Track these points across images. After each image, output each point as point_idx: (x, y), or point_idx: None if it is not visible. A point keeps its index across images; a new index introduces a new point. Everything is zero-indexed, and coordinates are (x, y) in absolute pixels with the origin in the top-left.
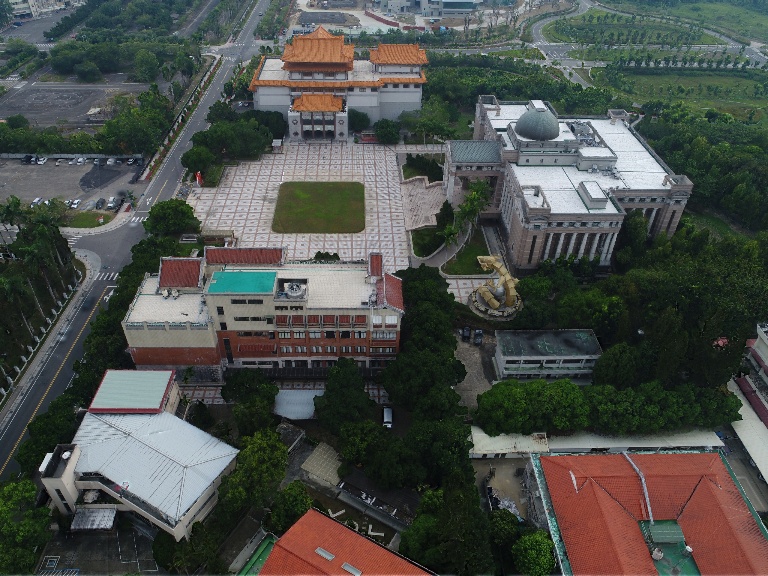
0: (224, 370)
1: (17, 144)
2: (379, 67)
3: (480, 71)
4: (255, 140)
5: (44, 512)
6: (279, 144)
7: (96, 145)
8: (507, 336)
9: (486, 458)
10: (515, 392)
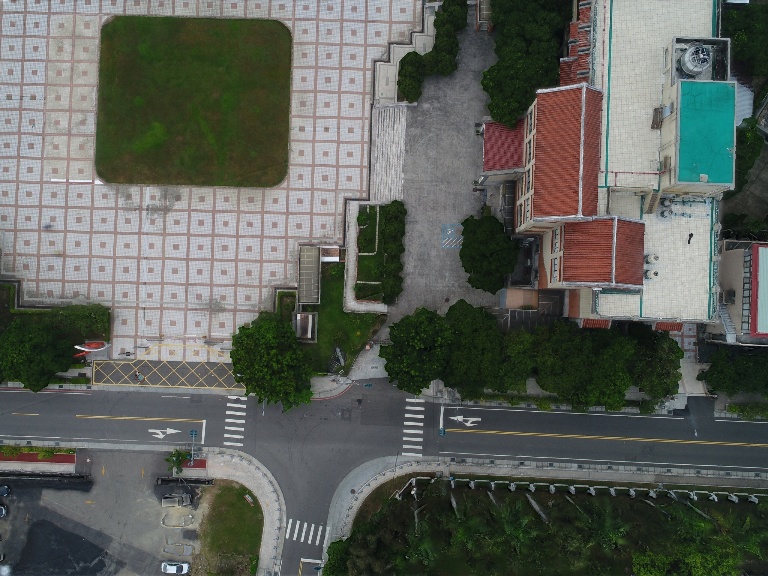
0: None
1: None
2: None
3: None
4: None
5: None
6: None
7: None
8: None
9: None
10: None
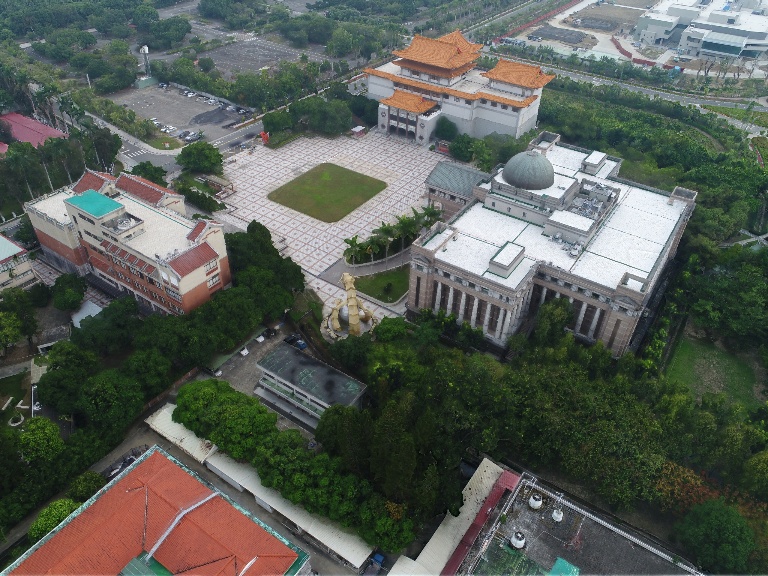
0: (86, 273)
1: (182, 78)
2: (492, 82)
3: (657, 119)
4: (334, 120)
5: None
6: (358, 130)
7: (227, 92)
8: (287, 351)
9: (166, 438)
10: (203, 390)
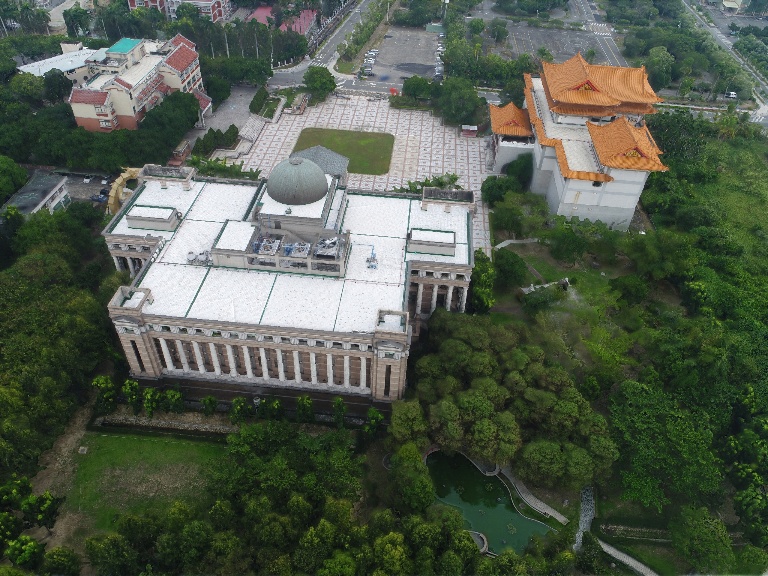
0: None
1: None
2: None
3: None
4: None
5: (56, 50)
6: (465, 128)
7: None
8: (57, 181)
9: None
10: None
